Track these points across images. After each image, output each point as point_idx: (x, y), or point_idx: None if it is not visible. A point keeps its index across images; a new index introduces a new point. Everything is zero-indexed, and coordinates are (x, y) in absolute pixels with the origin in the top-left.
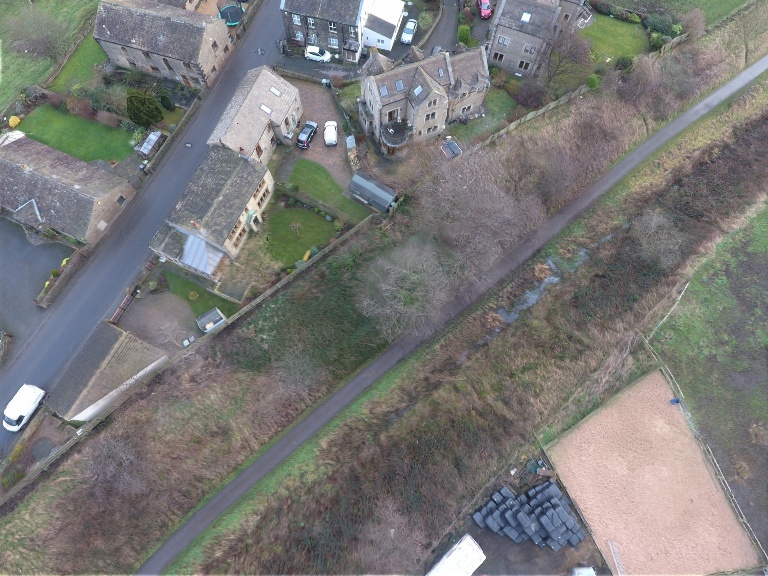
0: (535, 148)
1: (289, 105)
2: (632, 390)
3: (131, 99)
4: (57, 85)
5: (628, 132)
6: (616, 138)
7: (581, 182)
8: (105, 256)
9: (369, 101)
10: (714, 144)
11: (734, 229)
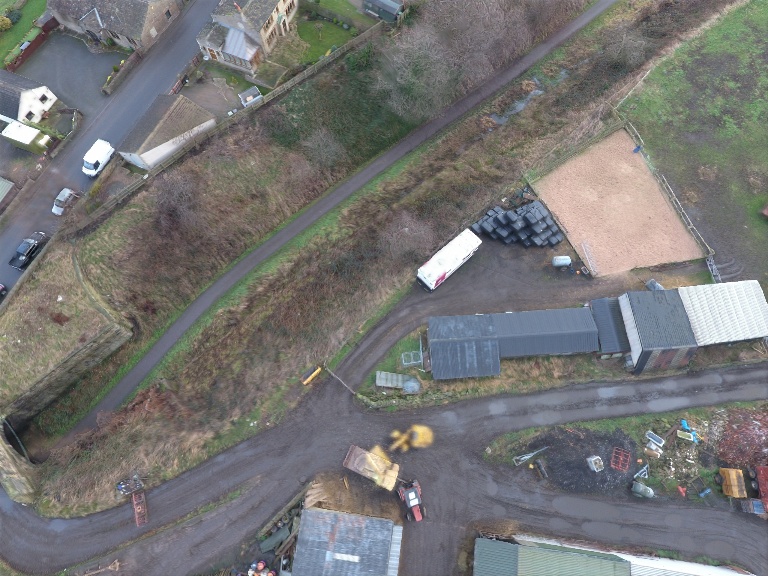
0: None
1: None
2: (602, 144)
3: None
4: None
5: None
6: None
7: (562, 18)
8: (157, 58)
9: None
10: None
11: (691, 38)
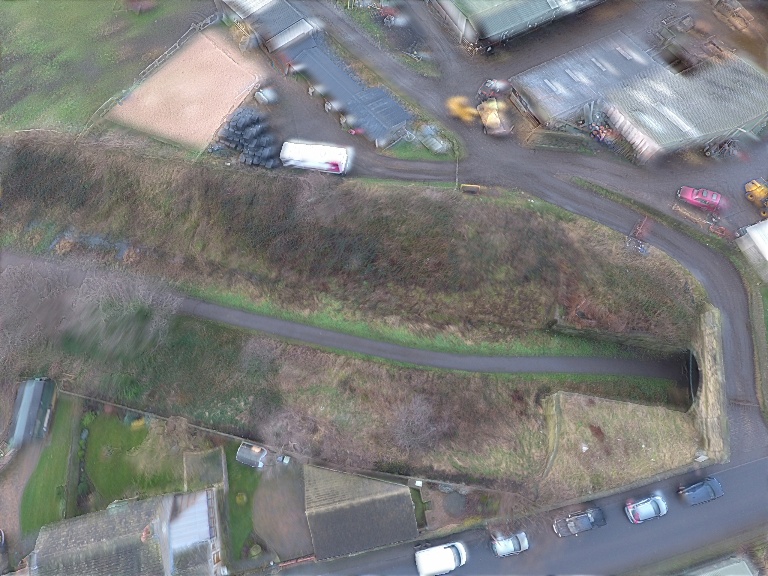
0: None
1: None
2: None
3: None
4: None
5: None
6: None
7: None
8: None
9: None
10: None
11: None
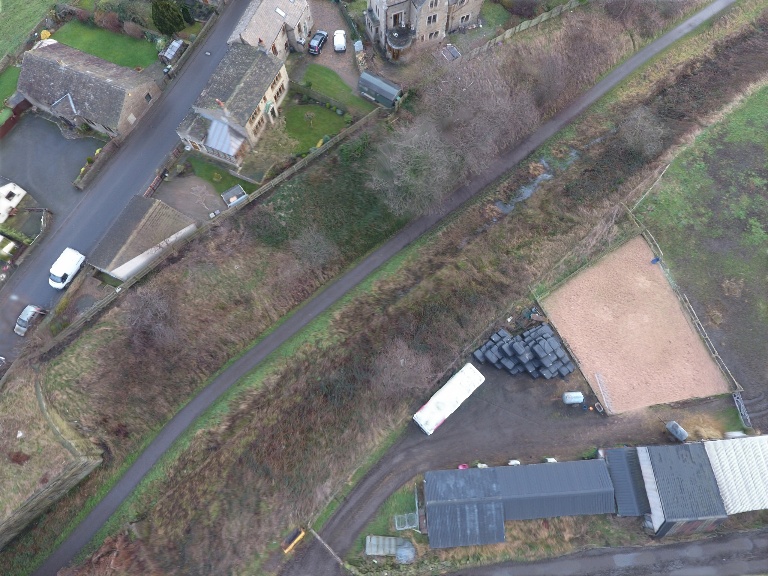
0: (529, 57)
1: (301, 11)
2: (617, 252)
3: (156, 4)
4: (83, 5)
5: (616, 46)
6: (604, 51)
7: (572, 92)
8: (135, 146)
9: (375, 7)
10: (696, 59)
11: (712, 123)
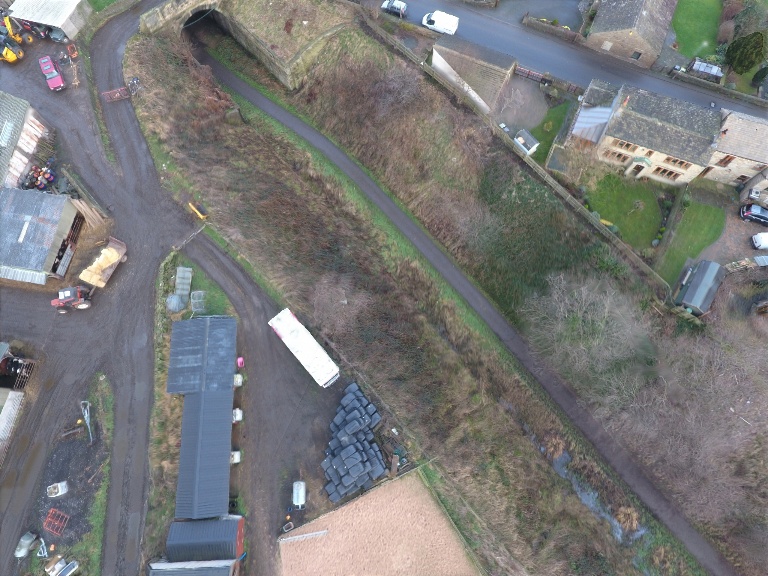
0: None
1: None
2: None
3: (758, 34)
4: None
5: None
6: None
7: None
8: (576, 55)
9: None
10: None
11: None
